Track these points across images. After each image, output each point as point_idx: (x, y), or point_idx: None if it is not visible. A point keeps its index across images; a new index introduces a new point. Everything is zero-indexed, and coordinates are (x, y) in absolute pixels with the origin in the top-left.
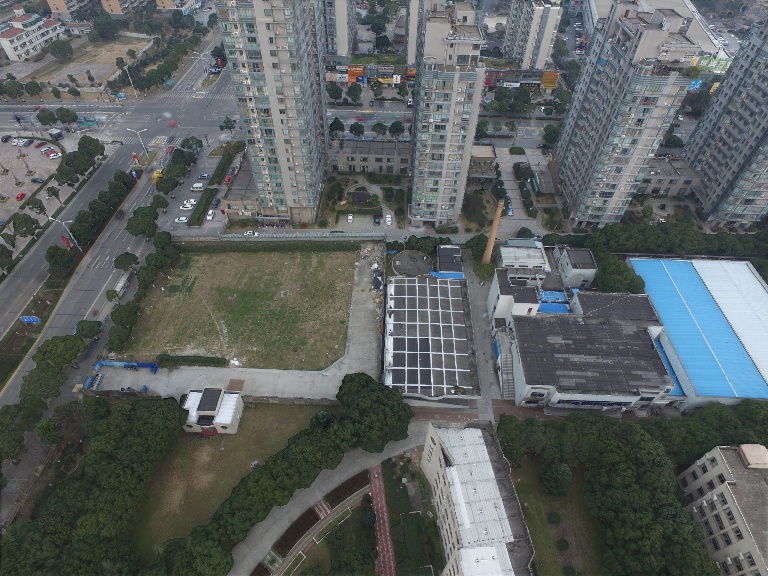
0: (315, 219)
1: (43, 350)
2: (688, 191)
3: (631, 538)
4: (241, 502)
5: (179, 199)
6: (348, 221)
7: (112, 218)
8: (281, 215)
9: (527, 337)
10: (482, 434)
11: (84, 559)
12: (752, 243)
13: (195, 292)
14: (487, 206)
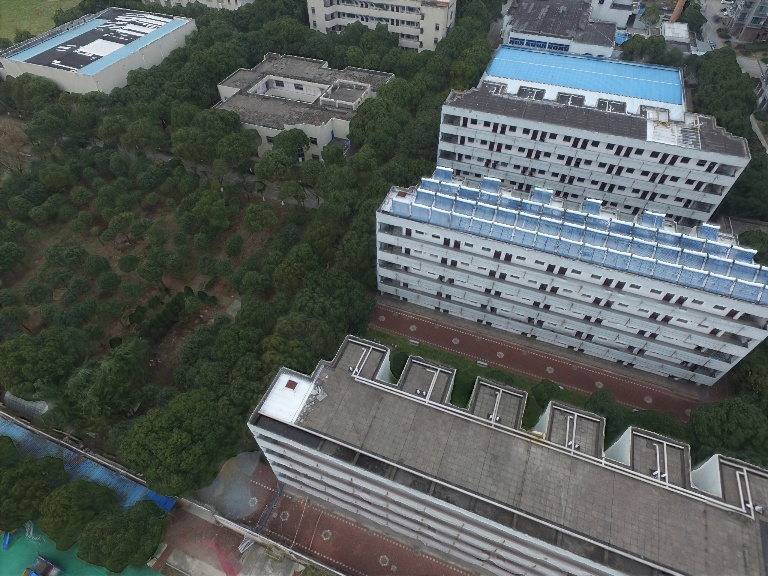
0: None
1: None
2: None
3: None
4: None
5: None
6: None
7: None
8: None
9: (567, 1)
10: None
11: None
12: None
13: None
14: None
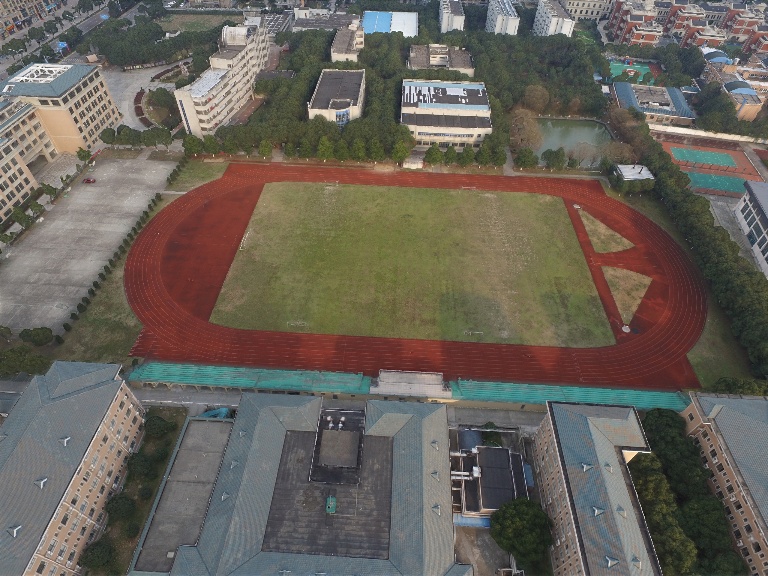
0: (232, 7)
1: (111, 20)
2: (420, 2)
3: (302, 41)
4: (180, 34)
5: (168, 2)
6: (247, 8)
7: (136, 6)
8: (215, 2)
9: None
10: (261, 18)
11: (130, 41)
12: (422, 7)
13: (172, 22)
14: (318, 6)
